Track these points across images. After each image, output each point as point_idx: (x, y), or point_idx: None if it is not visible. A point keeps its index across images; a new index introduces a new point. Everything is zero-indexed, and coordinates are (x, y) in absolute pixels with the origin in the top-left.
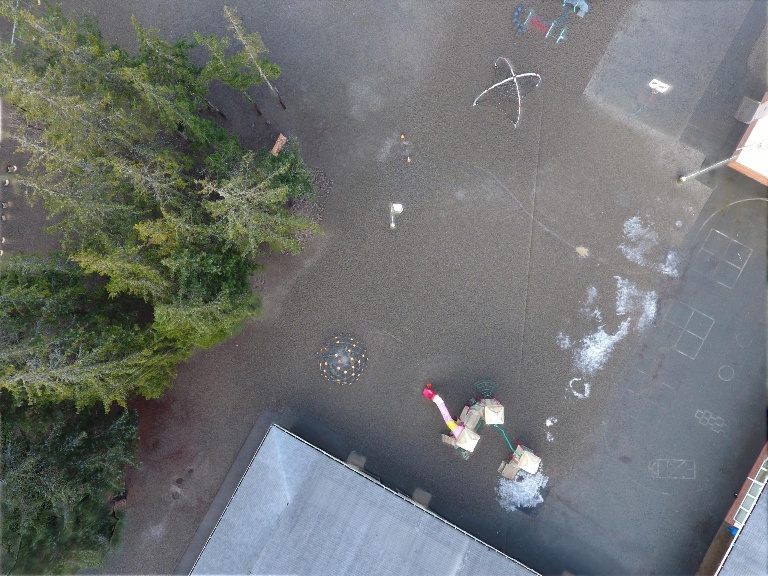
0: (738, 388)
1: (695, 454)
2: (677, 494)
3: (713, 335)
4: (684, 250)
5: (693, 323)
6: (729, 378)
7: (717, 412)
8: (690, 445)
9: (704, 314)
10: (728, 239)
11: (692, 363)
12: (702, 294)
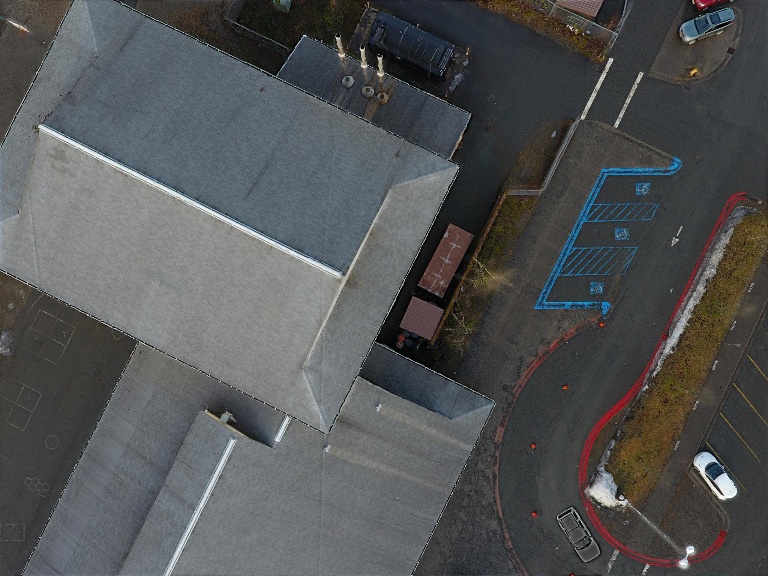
0: (62, 456)
1: (25, 518)
2: (9, 555)
3: (41, 408)
4: (15, 330)
5: (23, 397)
6: (54, 447)
7: (44, 478)
8: (20, 510)
9: (33, 389)
10: (54, 319)
11: (22, 434)
12: (31, 370)
